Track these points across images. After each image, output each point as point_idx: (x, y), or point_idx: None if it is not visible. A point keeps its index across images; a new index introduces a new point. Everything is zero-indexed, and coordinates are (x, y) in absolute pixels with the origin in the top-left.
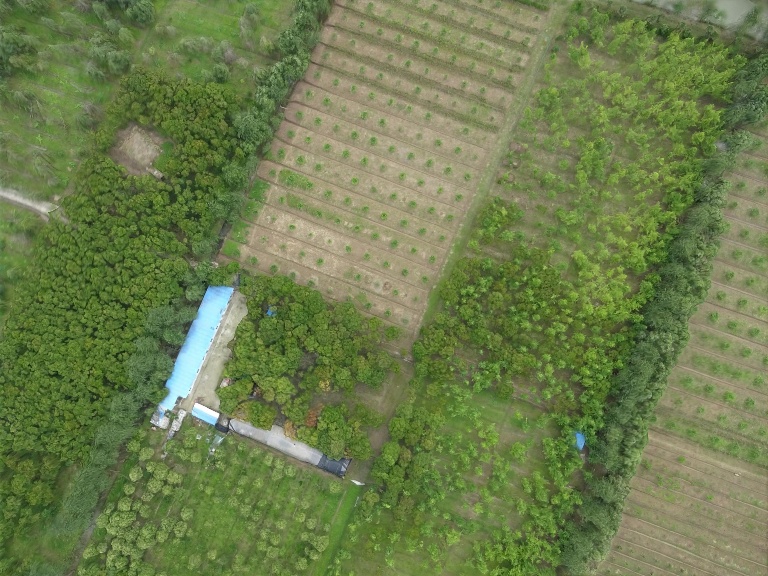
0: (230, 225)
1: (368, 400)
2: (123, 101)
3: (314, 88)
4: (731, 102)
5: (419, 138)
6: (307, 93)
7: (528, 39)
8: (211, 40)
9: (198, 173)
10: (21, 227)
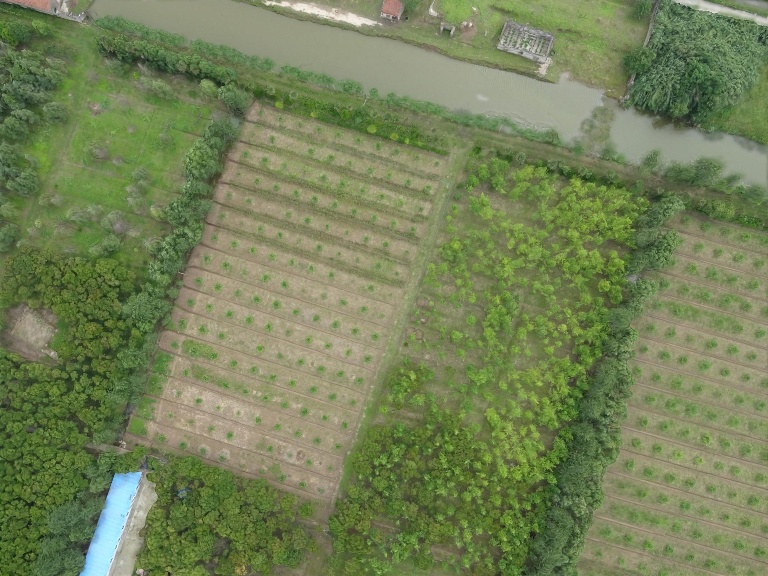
0: None
1: (289, 574)
2: (9, 286)
3: (212, 251)
4: (635, 248)
5: (324, 298)
6: (204, 259)
7: (429, 188)
8: (100, 209)
9: (94, 359)
10: None
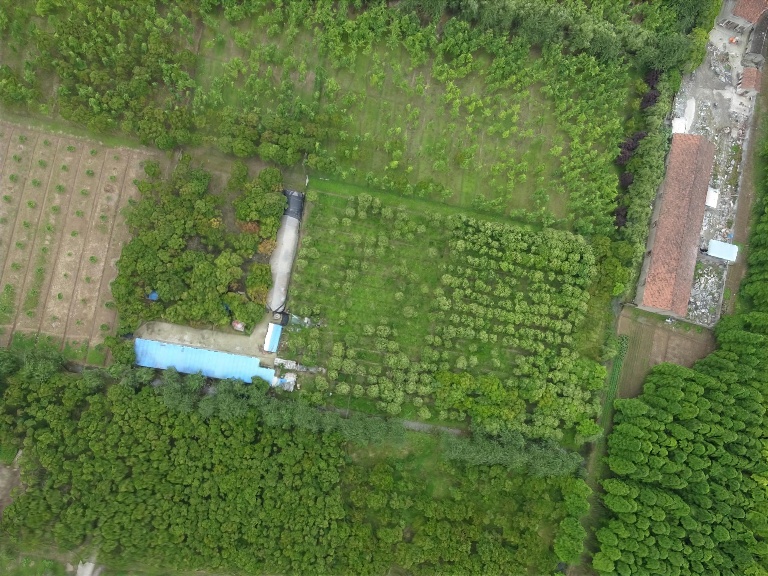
0: (69, 364)
1: None
2: None
3: None
4: None
5: None
6: None
7: None
8: None
9: (6, 403)
10: None
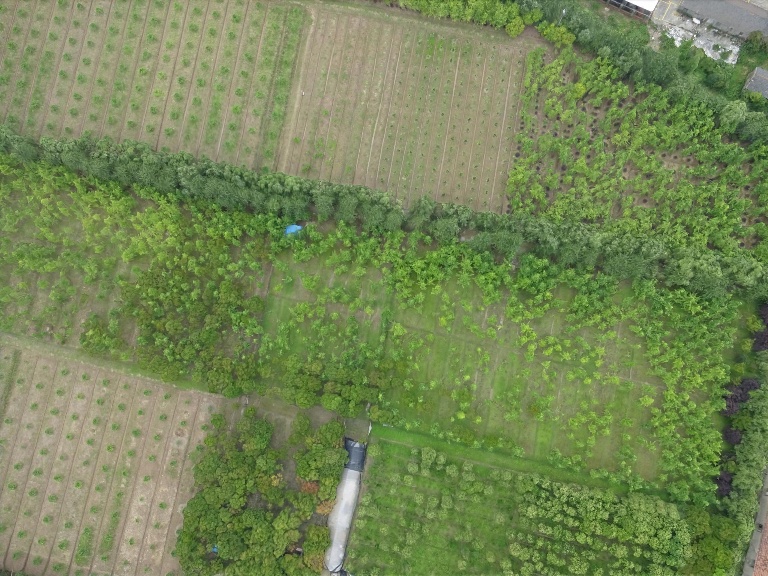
0: None
1: None
2: None
3: None
4: None
5: (31, 427)
6: None
7: None
8: None
9: None
10: None
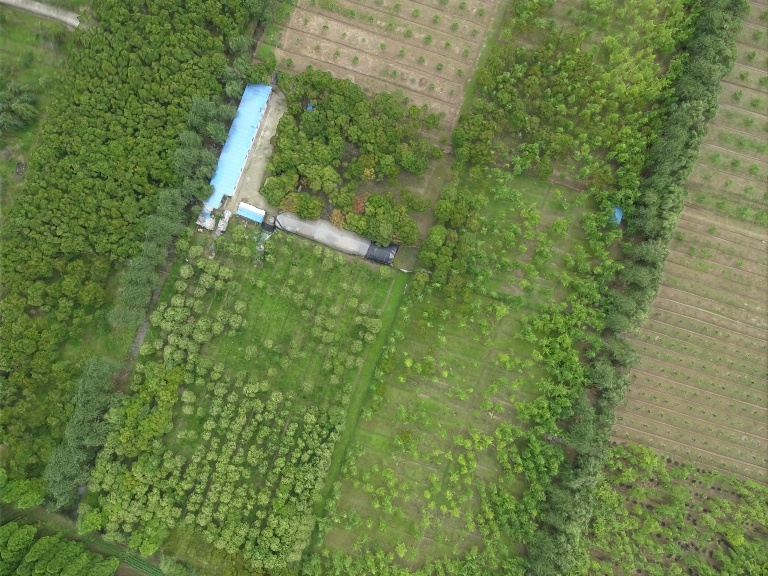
0: (262, 29)
1: None
2: None
3: None
4: None
5: None
6: None
7: None
8: None
9: None
10: (49, 36)
